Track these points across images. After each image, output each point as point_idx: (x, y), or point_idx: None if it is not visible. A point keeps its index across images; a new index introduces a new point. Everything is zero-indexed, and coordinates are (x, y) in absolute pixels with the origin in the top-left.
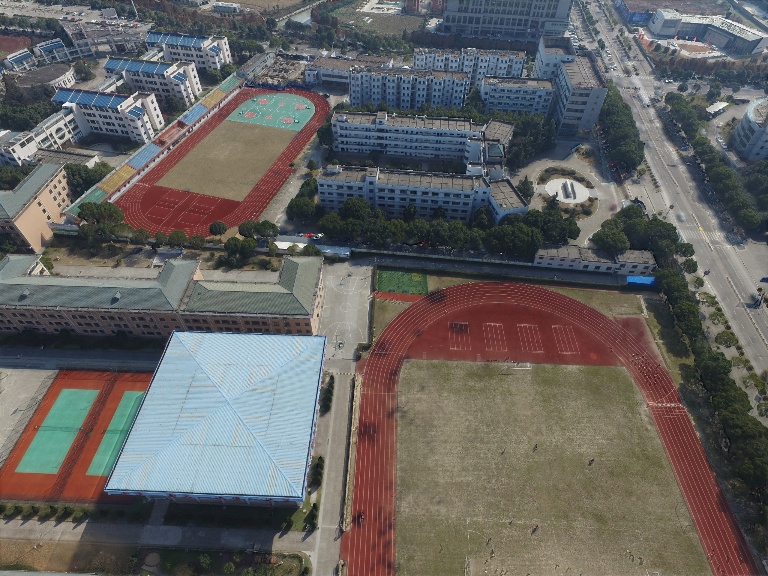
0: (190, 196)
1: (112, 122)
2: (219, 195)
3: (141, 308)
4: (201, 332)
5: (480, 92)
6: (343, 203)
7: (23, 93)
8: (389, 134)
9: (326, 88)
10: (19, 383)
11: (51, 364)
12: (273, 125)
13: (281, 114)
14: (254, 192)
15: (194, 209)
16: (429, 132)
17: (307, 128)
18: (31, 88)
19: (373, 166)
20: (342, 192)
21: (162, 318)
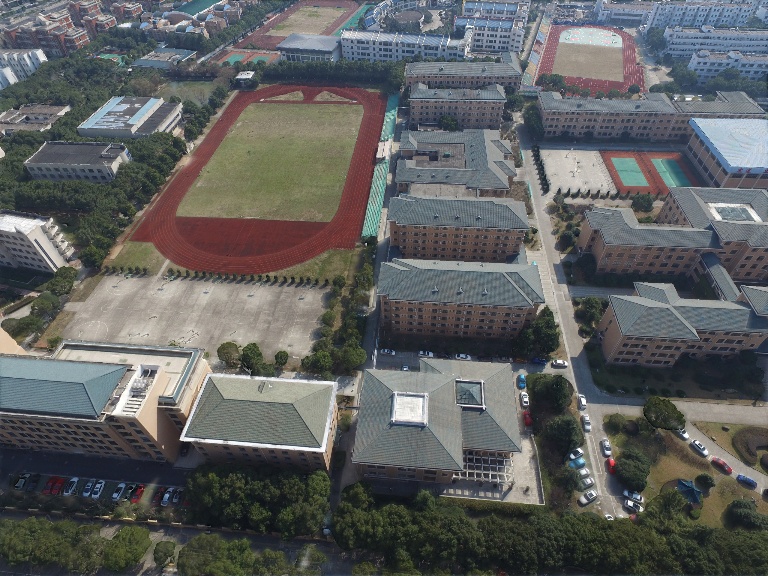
0: (584, 79)
1: (495, 40)
2: (604, 79)
3: (656, 111)
4: (709, 118)
5: (758, 17)
6: (708, 77)
7: (411, 26)
8: (713, 40)
9: (614, 24)
10: (581, 155)
11: (590, 149)
12: (599, 44)
13: (598, 38)
14: (627, 77)
15: (595, 85)
16: (744, 38)
17: (626, 46)
18: (411, 23)
19: (735, 50)
20: (712, 68)
21: (662, 120)
